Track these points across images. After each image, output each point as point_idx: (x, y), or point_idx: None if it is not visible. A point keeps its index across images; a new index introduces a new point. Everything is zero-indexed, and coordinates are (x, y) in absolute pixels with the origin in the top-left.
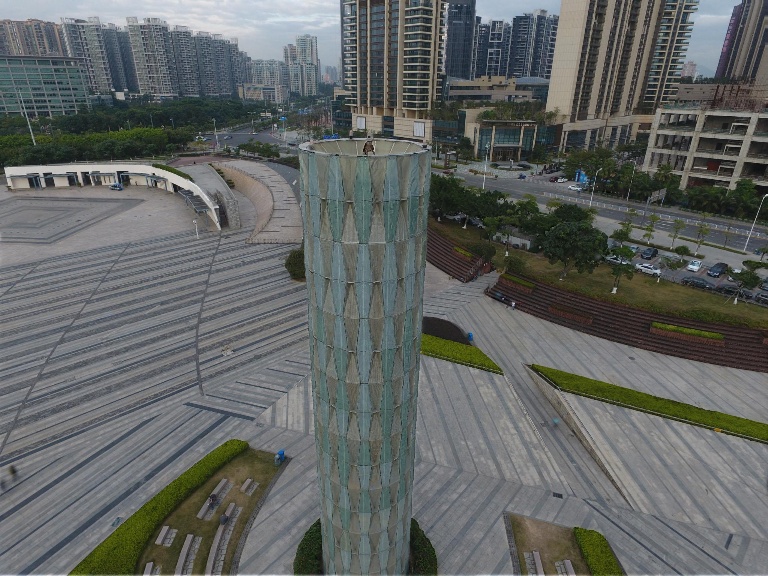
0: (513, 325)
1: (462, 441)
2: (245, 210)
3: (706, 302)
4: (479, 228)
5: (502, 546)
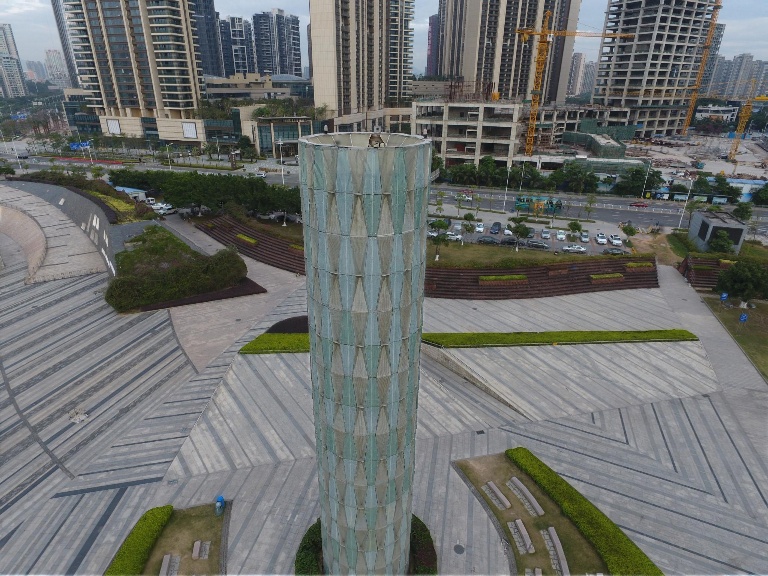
0: None
1: None
2: None
3: (499, 254)
4: (298, 224)
5: (464, 490)
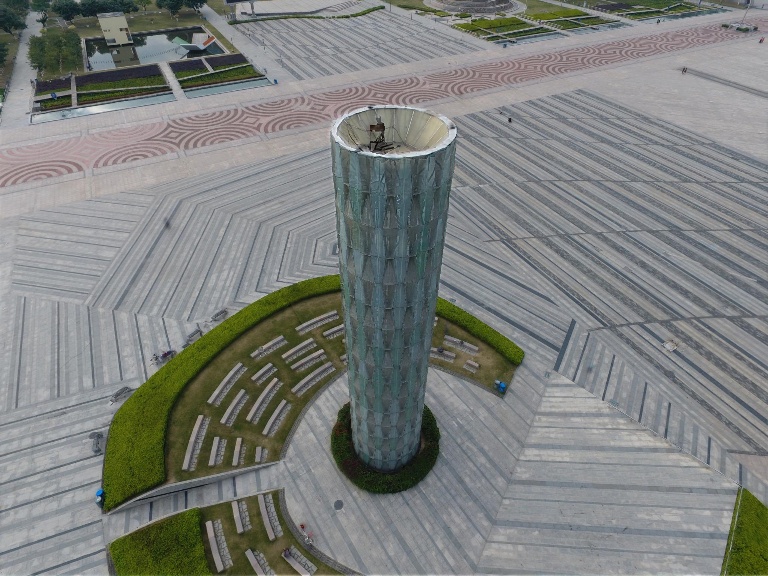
0: None
1: None
2: None
3: None
4: None
5: (375, 570)
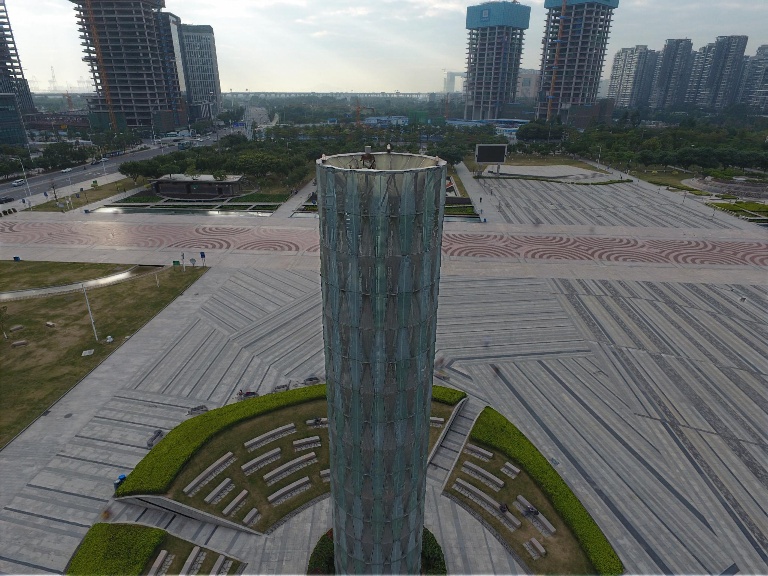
0: None
1: None
2: None
3: None
4: None
5: None
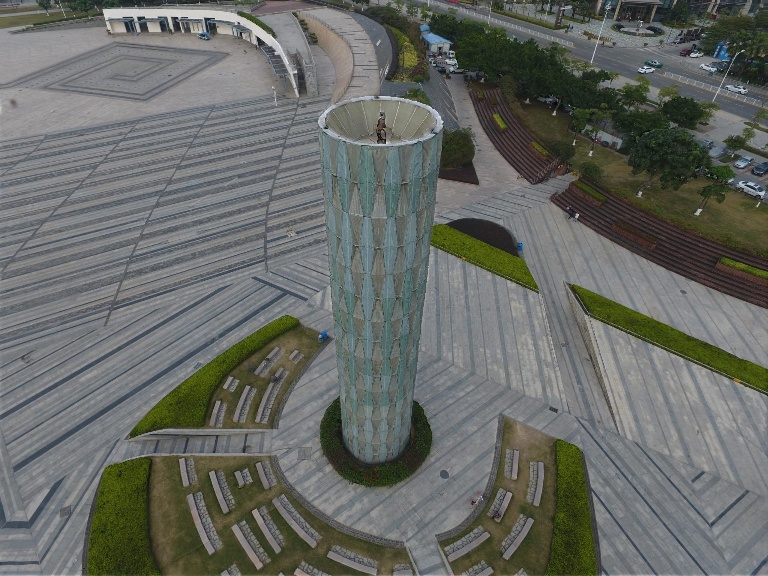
0: (569, 239)
1: (481, 348)
2: (325, 73)
3: None
4: (570, 116)
5: (490, 441)
